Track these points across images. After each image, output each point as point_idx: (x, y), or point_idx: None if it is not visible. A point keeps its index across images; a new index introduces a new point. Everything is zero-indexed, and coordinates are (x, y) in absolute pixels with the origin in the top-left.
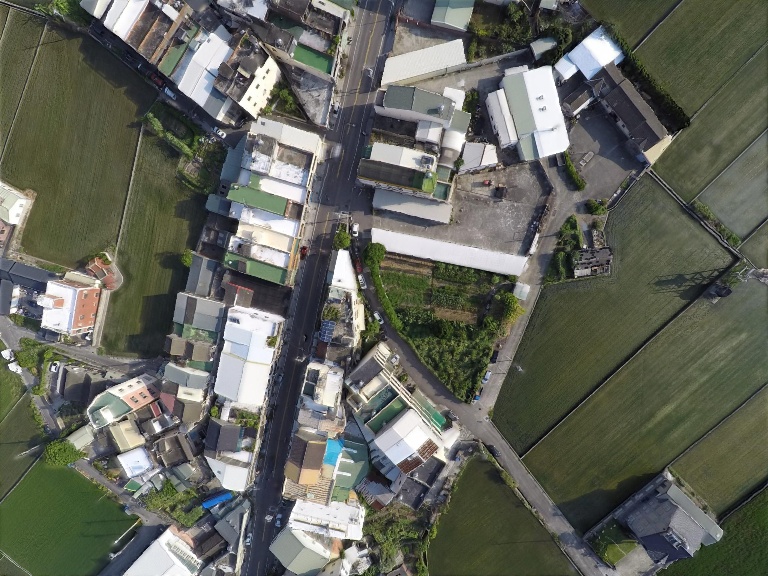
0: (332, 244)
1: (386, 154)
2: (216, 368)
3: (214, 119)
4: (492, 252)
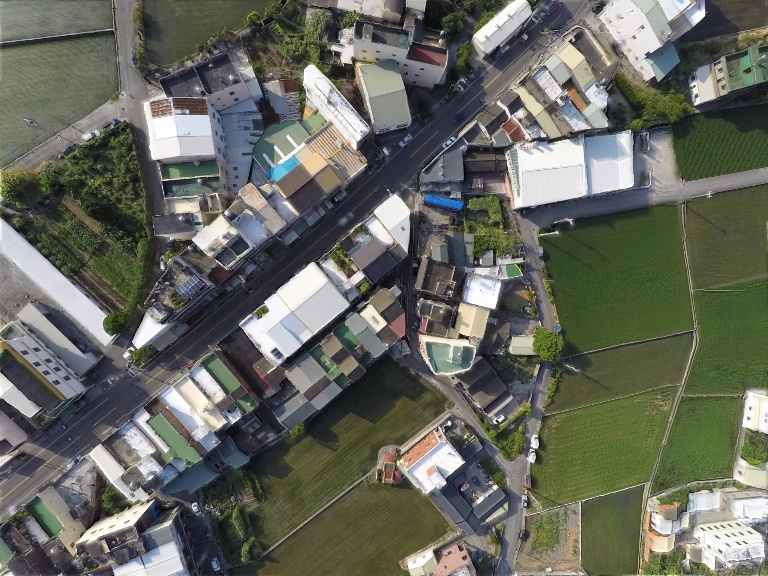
0: (163, 356)
1: (23, 402)
2: (340, 323)
3: (195, 522)
4: (2, 250)
